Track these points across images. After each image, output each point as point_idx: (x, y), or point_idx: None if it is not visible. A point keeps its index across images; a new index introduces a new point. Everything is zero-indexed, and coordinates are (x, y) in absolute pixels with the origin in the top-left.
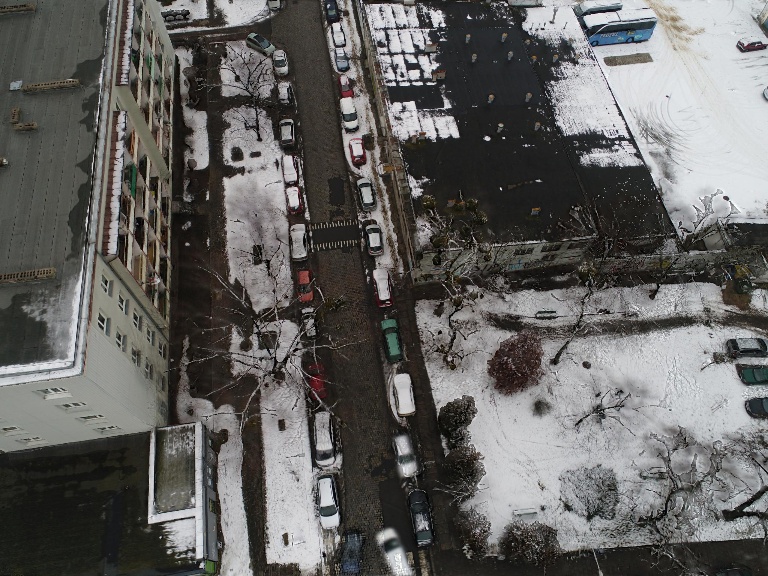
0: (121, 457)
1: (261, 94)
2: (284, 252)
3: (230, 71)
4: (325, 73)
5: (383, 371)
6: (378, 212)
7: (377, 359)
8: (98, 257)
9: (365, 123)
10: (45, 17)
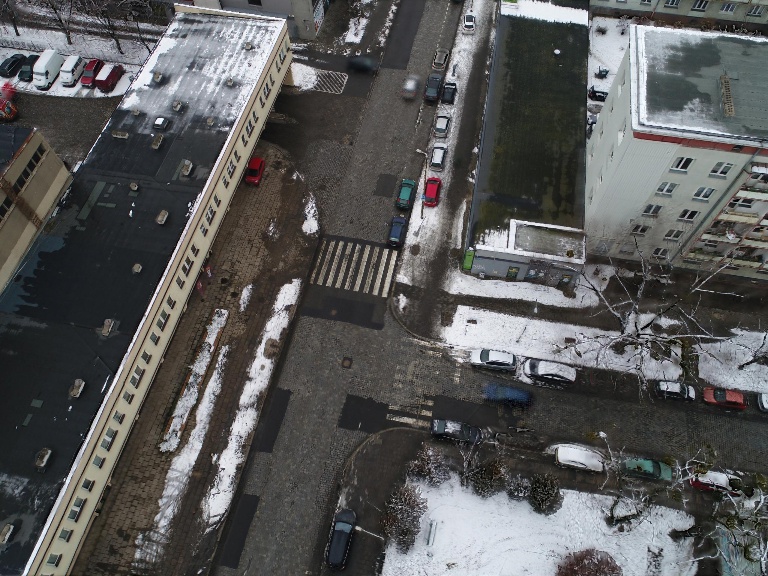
0: (567, 212)
1: None
2: None
3: None
4: None
5: None
6: None
7: None
8: (749, 157)
9: None
10: None
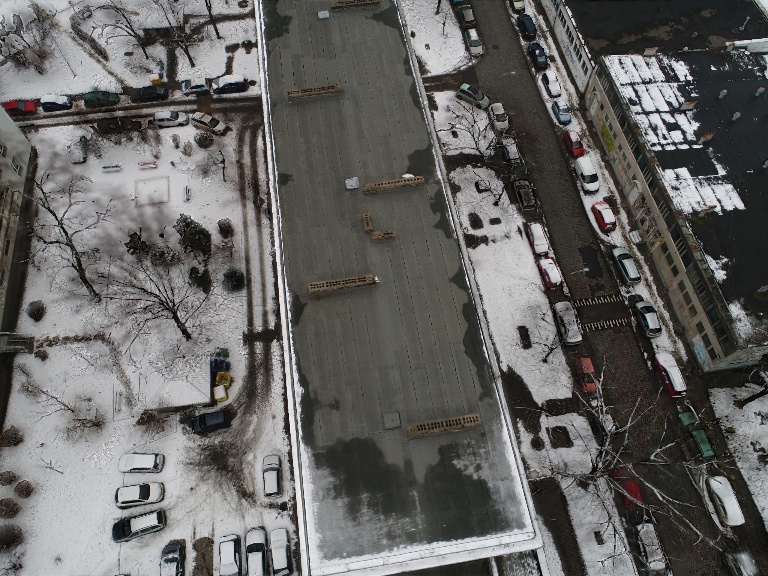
0: None
1: (485, 152)
2: (552, 334)
3: (445, 126)
4: (546, 127)
5: (692, 472)
6: (641, 286)
7: (682, 458)
8: None
9: (603, 183)
10: (354, 99)
